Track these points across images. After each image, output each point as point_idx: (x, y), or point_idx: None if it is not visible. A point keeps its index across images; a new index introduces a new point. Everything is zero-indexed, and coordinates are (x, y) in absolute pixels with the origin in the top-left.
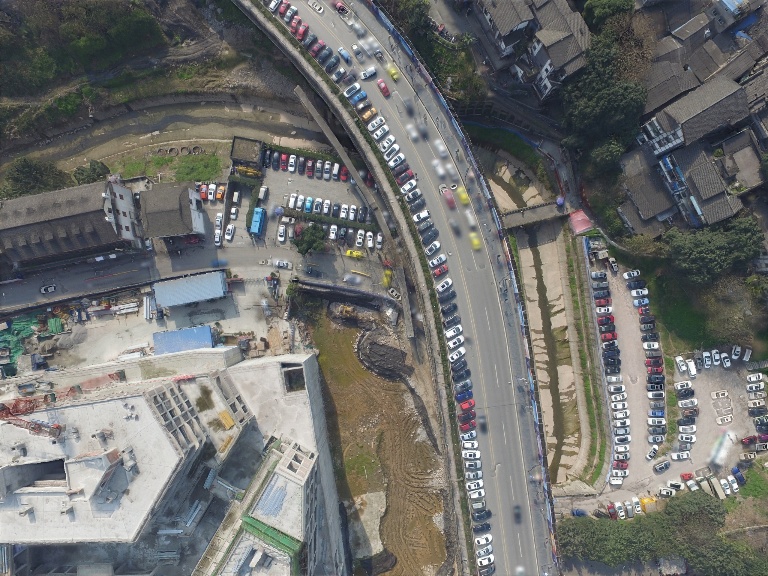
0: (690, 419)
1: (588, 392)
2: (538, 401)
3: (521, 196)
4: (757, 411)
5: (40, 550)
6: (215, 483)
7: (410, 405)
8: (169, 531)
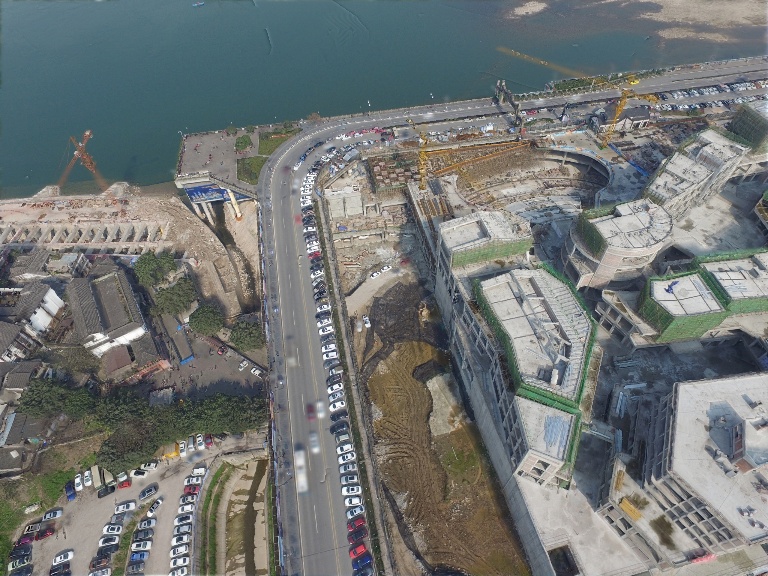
0: (103, 554)
1: (212, 573)
2: (277, 566)
3: None
4: (22, 573)
5: (742, 356)
6: (612, 436)
7: (418, 536)
8: (637, 386)
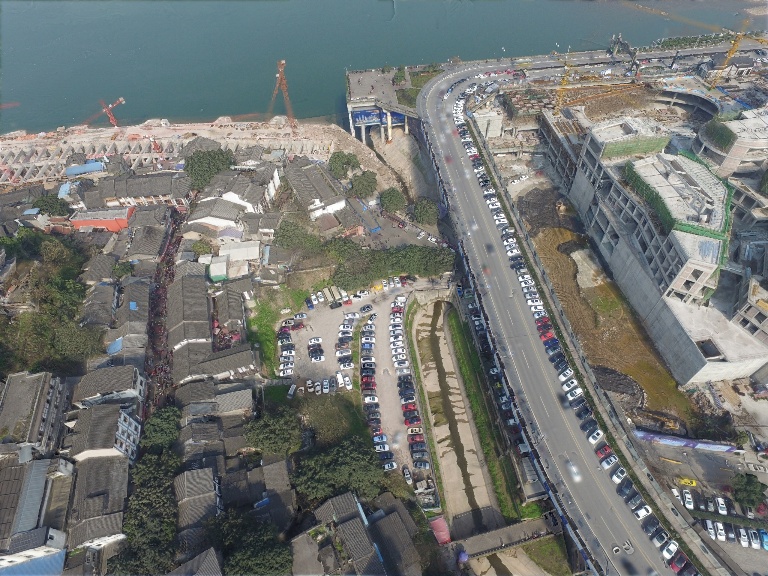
0: (344, 341)
1: (417, 367)
2: (491, 338)
3: (498, 574)
4: (289, 347)
5: None
6: (743, 271)
7: None
8: (760, 243)
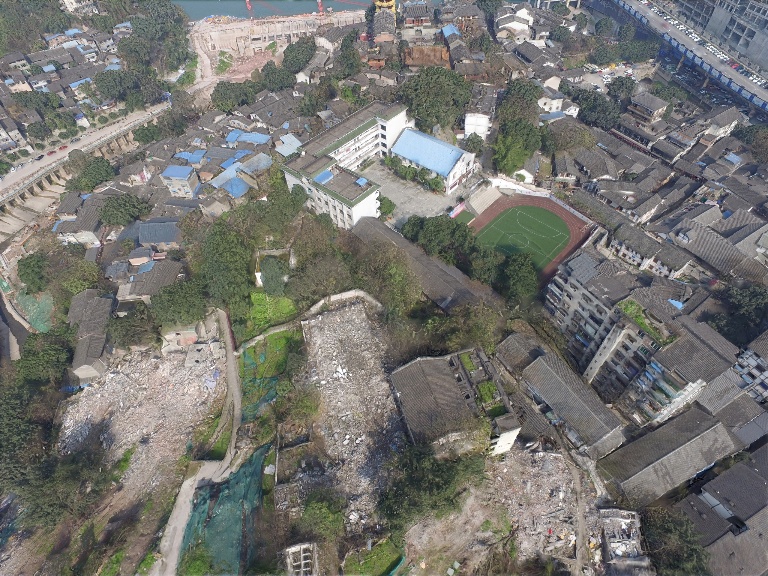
0: None
1: None
2: (708, 64)
3: None
4: None
5: None
6: None
7: None
8: None
